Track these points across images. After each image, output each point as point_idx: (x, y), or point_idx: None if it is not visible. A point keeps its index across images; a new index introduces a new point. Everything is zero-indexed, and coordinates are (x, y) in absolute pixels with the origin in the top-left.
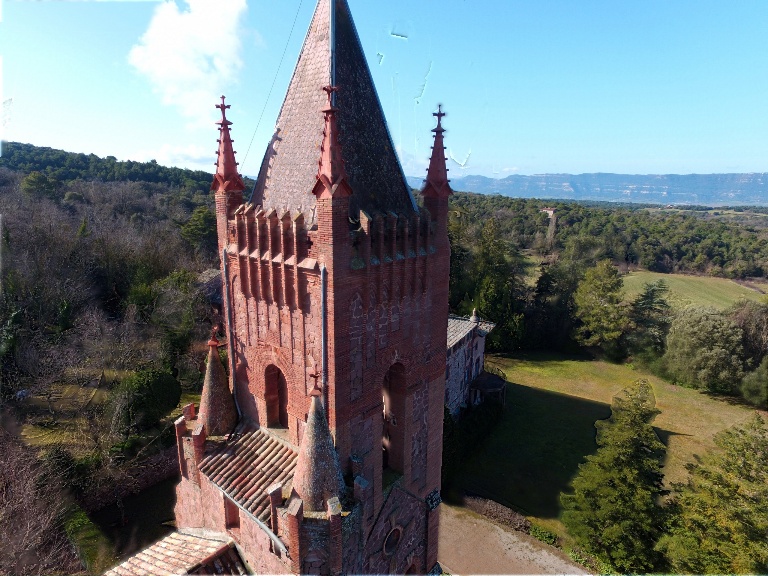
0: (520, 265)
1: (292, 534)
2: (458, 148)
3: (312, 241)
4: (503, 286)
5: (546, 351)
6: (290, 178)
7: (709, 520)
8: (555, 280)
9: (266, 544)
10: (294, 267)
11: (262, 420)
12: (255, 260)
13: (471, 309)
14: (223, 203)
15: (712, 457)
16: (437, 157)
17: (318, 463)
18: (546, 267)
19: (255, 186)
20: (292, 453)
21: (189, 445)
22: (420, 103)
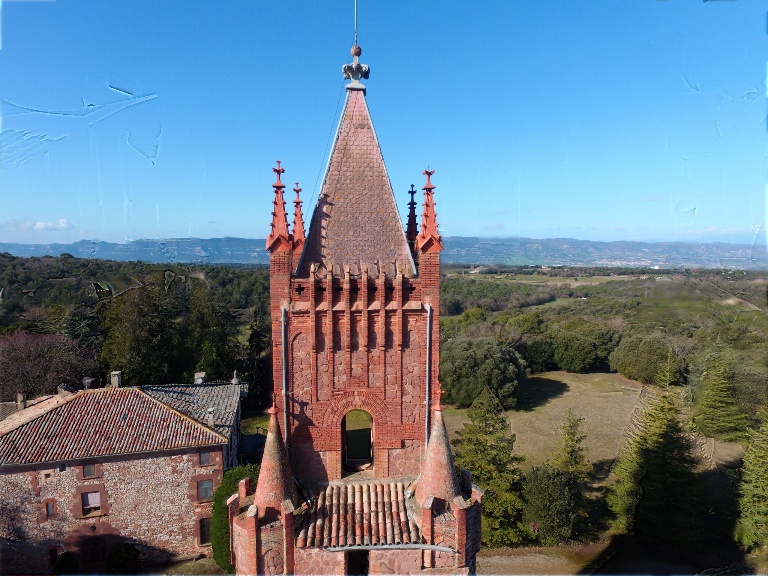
0: (233, 325)
1: (461, 528)
2: (183, 211)
3: (414, 287)
4: (224, 348)
5: (269, 404)
6: (356, 238)
7: (478, 471)
8: (265, 335)
9: (417, 565)
10: (398, 311)
11: (333, 474)
12: (339, 313)
13: (222, 373)
14: (285, 263)
15: (468, 428)
16: (415, 223)
17: (452, 465)
18: (254, 324)
19: (306, 246)
20: (384, 486)
21: (273, 532)
22: (130, 162)
